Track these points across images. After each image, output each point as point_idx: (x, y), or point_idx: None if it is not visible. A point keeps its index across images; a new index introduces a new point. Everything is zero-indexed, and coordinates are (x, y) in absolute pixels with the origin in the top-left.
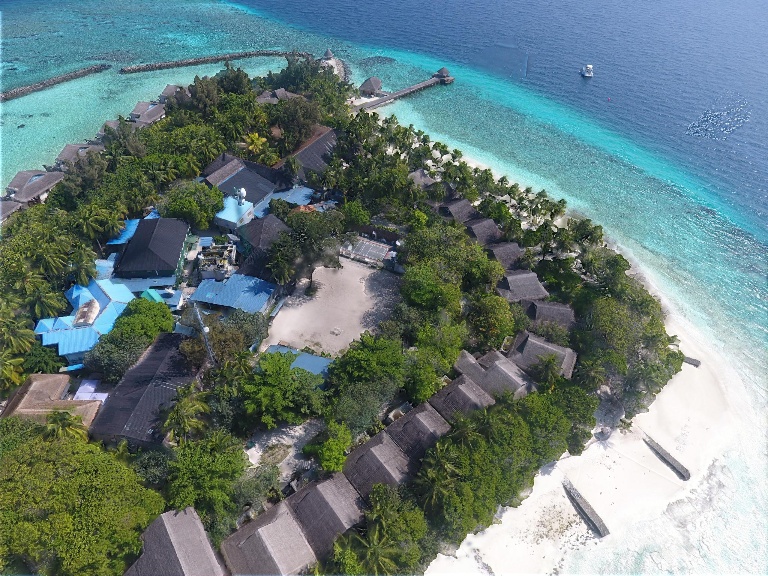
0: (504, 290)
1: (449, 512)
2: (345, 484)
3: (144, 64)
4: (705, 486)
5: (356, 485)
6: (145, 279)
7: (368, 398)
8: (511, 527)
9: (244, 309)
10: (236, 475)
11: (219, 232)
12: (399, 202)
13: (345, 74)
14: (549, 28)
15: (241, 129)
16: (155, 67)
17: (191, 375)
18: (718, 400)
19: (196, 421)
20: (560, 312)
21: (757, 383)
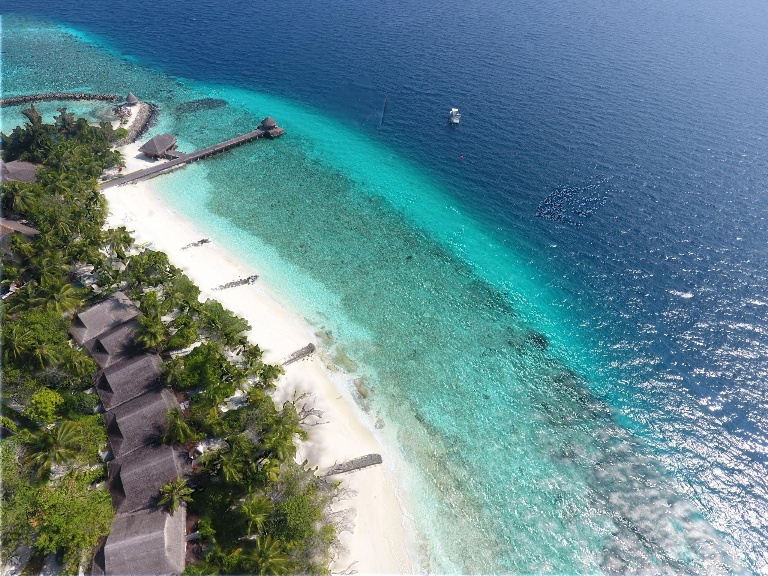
0: (98, 570)
1: None
2: None
3: None
4: None
5: None
6: None
7: None
8: None
9: None
10: None
11: None
12: (22, 374)
13: (144, 125)
14: (410, 66)
15: None
16: None
17: None
18: None
19: None
20: None
21: None
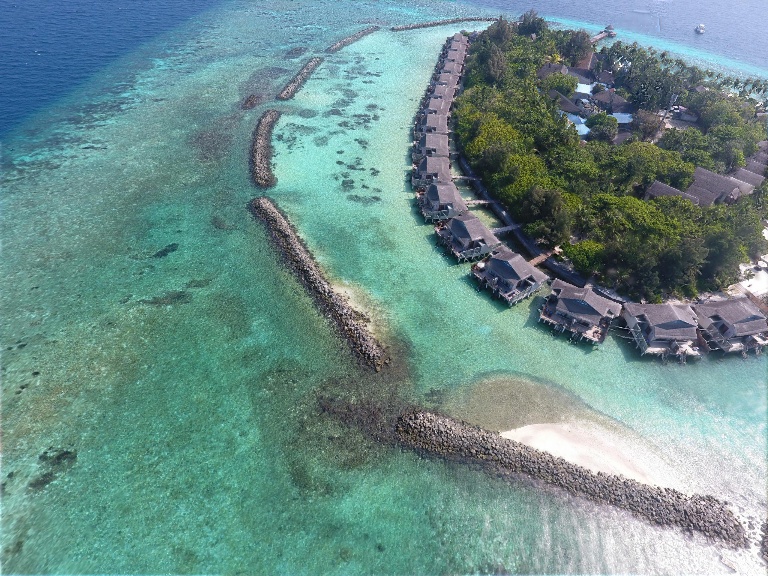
0: None
1: None
2: None
3: None
4: None
5: None
6: None
7: None
8: None
9: None
10: None
11: None
12: None
13: None
14: None
15: None
16: (411, 27)
17: None
18: None
19: None
20: None
21: None
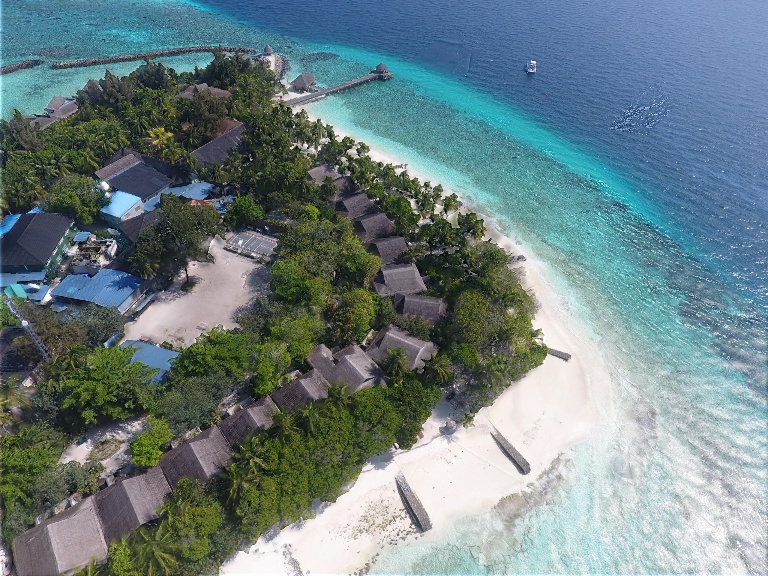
0: (380, 284)
1: (241, 507)
2: (159, 479)
3: (79, 60)
4: (544, 480)
5: (171, 480)
6: (13, 274)
7: (197, 392)
8: (331, 522)
9: (102, 304)
10: (35, 470)
11: (108, 227)
12: (292, 196)
13: (282, 70)
14: (492, 24)
15: (146, 124)
16: (89, 63)
17: (26, 370)
18: (580, 394)
19: (3, 416)
20: (428, 306)
21: (624, 377)
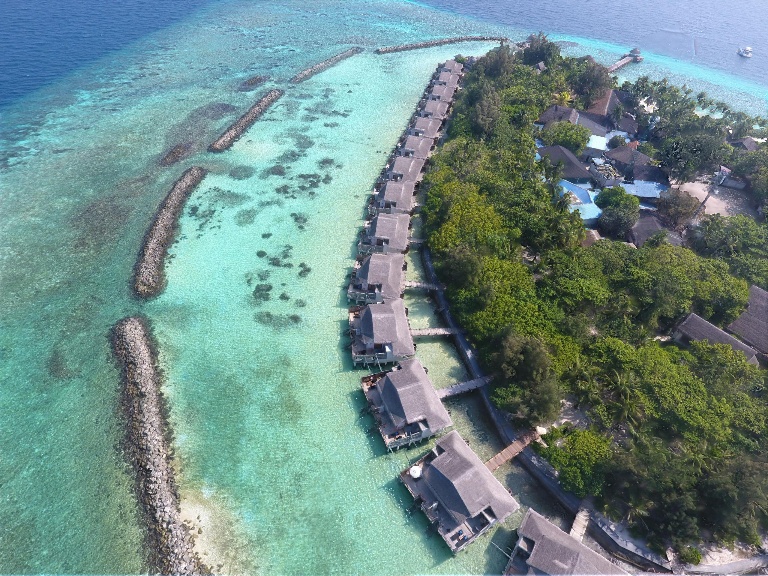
0: None
1: None
2: None
3: None
4: None
5: None
6: None
7: None
8: None
9: None
10: None
11: None
12: None
13: None
14: (713, 15)
15: (554, 89)
16: (399, 49)
17: (675, 231)
18: None
19: None
20: None
21: None
